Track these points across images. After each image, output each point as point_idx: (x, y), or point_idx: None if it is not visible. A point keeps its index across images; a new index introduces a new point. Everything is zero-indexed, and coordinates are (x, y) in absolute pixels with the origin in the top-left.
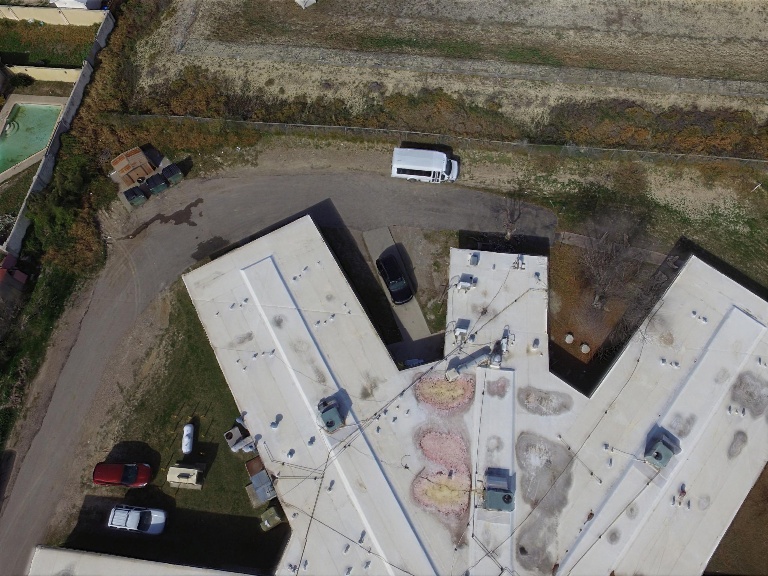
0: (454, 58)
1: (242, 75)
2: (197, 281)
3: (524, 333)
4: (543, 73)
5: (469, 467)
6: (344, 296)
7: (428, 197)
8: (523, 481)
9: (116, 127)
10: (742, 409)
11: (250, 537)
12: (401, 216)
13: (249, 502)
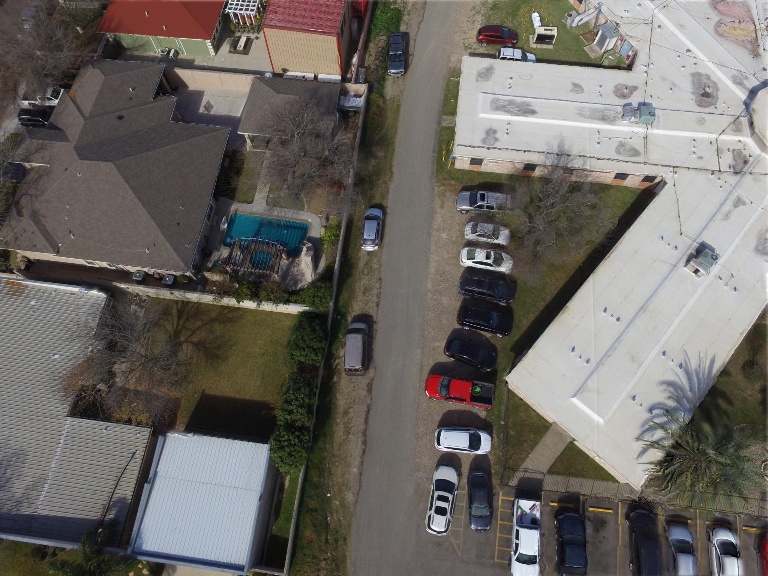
0: None
1: None
2: None
3: None
4: None
5: (752, 19)
6: None
7: None
8: None
9: None
10: None
11: None
12: None
13: (588, 55)
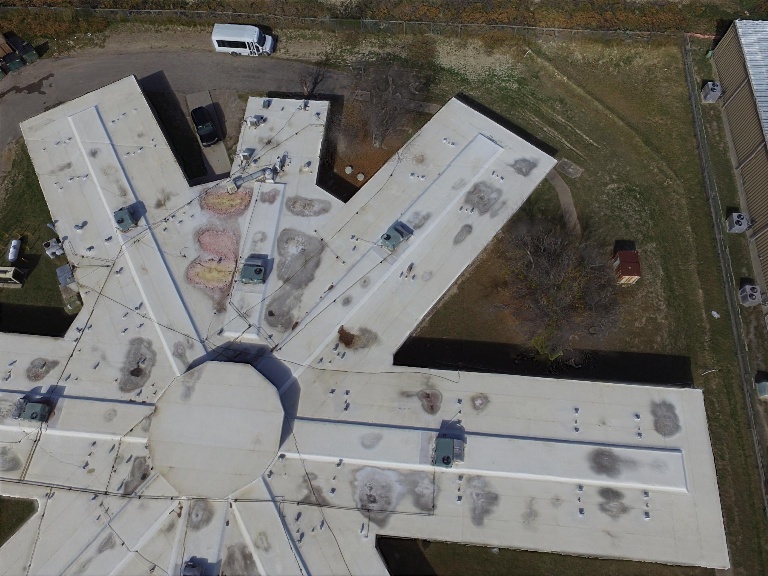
0: None
1: None
2: (31, 126)
3: (299, 157)
4: None
5: (236, 255)
6: (153, 134)
7: (247, 67)
8: (279, 264)
9: None
10: (472, 208)
11: (59, 322)
12: (221, 82)
13: (61, 296)
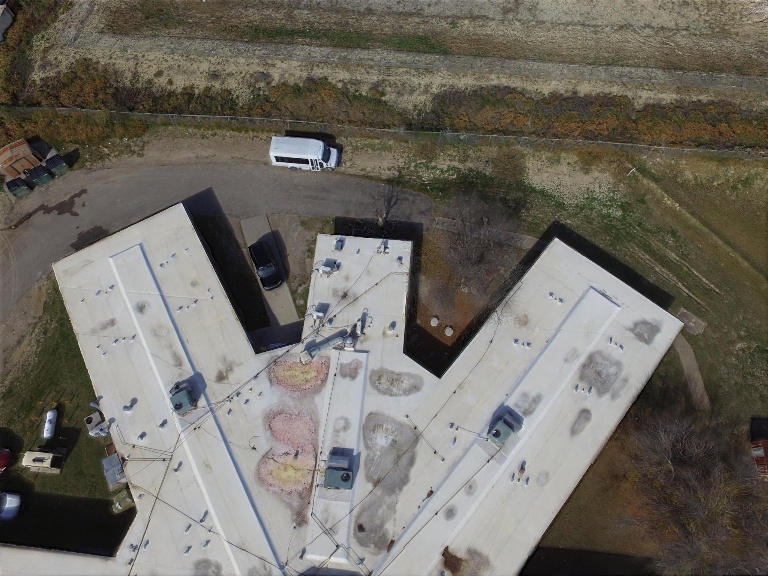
0: (342, 48)
1: (132, 67)
2: (66, 269)
3: (382, 316)
4: (428, 61)
5: (315, 447)
6: (208, 282)
7: (308, 185)
8: (367, 460)
9: (5, 120)
10: (589, 387)
11: (105, 519)
12: (280, 204)
13: (106, 485)
